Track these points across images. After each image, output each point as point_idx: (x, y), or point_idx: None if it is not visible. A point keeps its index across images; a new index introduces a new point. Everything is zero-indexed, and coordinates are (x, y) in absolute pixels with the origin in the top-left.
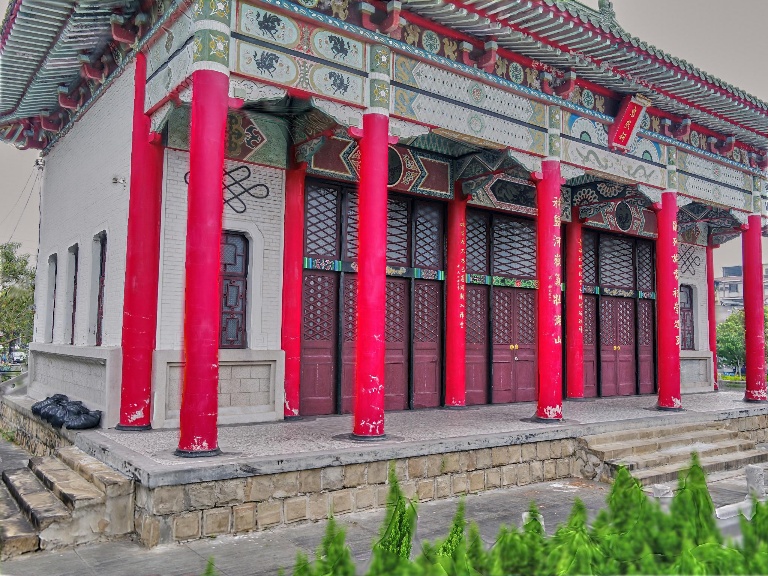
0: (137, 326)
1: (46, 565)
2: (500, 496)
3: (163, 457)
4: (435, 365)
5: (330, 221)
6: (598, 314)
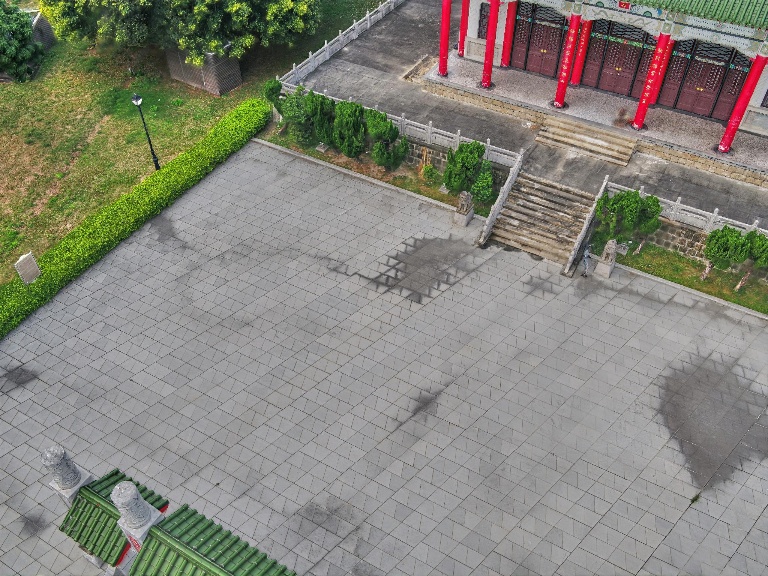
0: (461, 29)
1: (408, 85)
2: (504, 117)
3: (435, 72)
4: (571, 65)
5: (530, 3)
6: (686, 68)
